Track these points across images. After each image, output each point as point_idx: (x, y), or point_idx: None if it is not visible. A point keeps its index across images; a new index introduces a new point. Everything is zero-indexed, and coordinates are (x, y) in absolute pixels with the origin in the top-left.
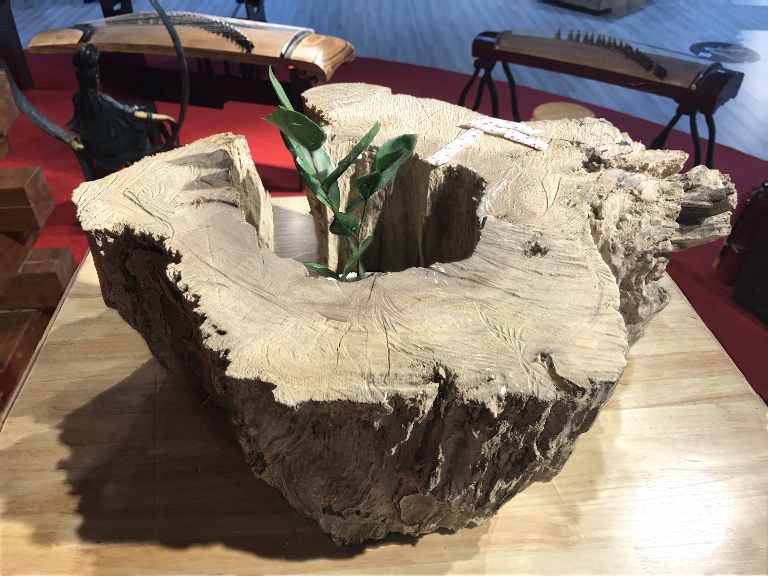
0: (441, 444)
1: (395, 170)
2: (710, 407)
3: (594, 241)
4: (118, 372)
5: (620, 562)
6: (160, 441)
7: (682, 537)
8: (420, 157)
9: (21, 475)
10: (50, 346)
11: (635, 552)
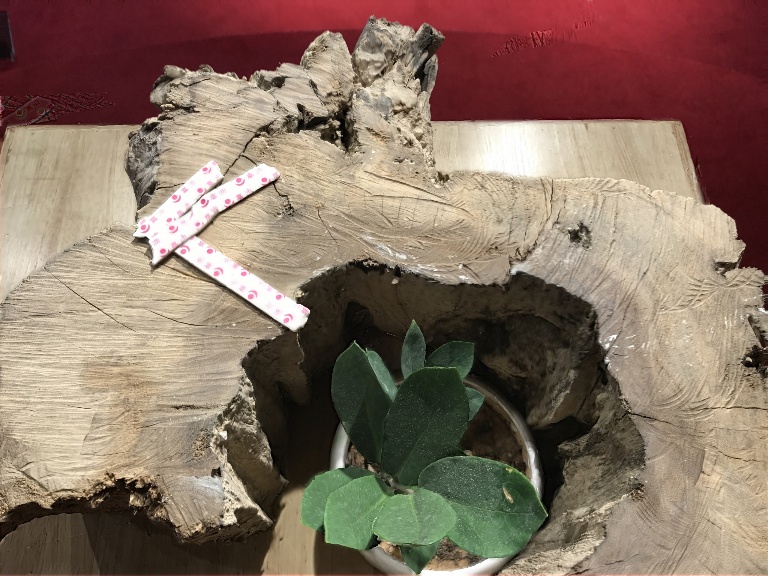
0: None
1: (387, 372)
2: None
3: None
4: None
5: None
6: None
7: None
8: (270, 338)
9: None
10: None
11: None
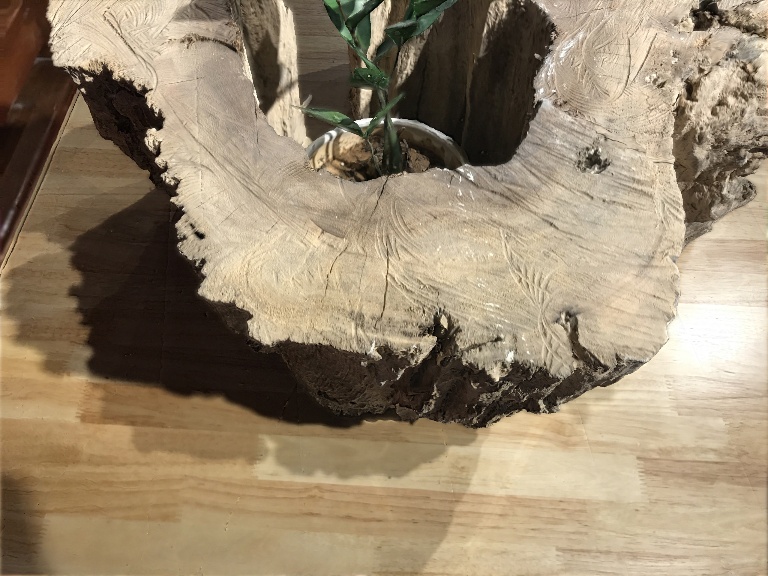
0: (436, 383)
1: None
2: (765, 312)
3: (678, 126)
4: (131, 192)
5: (618, 470)
6: (170, 277)
7: (690, 453)
8: None
9: (34, 297)
10: (62, 153)
11: (636, 462)
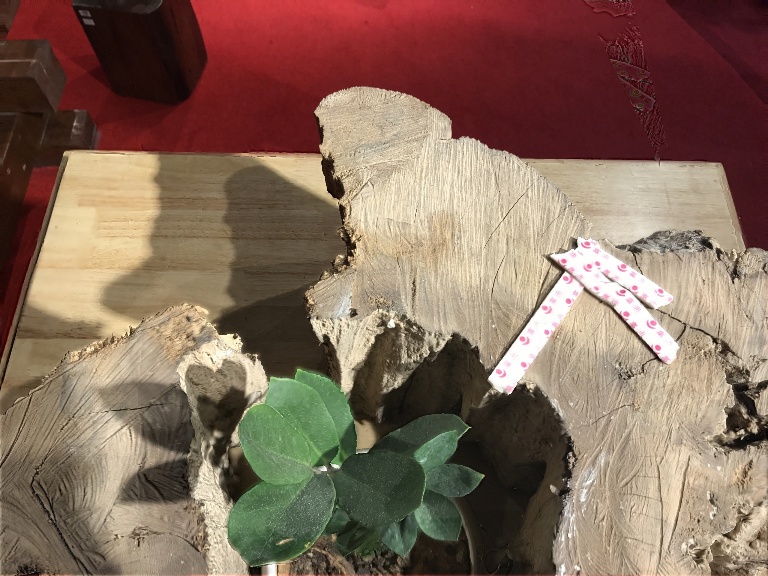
0: None
1: (441, 463)
2: None
3: (711, 551)
4: None
5: None
6: None
7: None
8: (482, 358)
9: None
10: None
11: None
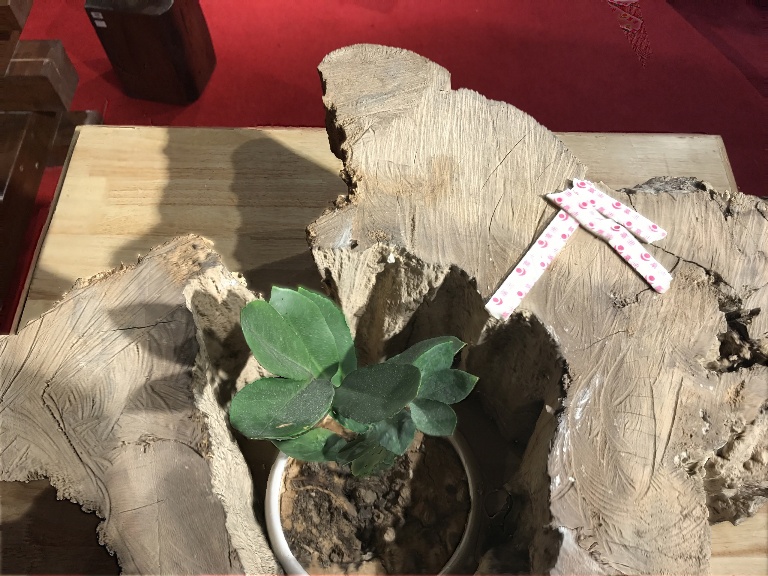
0: None
1: None
2: None
3: None
4: None
5: None
6: None
7: None
8: (479, 289)
9: None
10: None
11: None
